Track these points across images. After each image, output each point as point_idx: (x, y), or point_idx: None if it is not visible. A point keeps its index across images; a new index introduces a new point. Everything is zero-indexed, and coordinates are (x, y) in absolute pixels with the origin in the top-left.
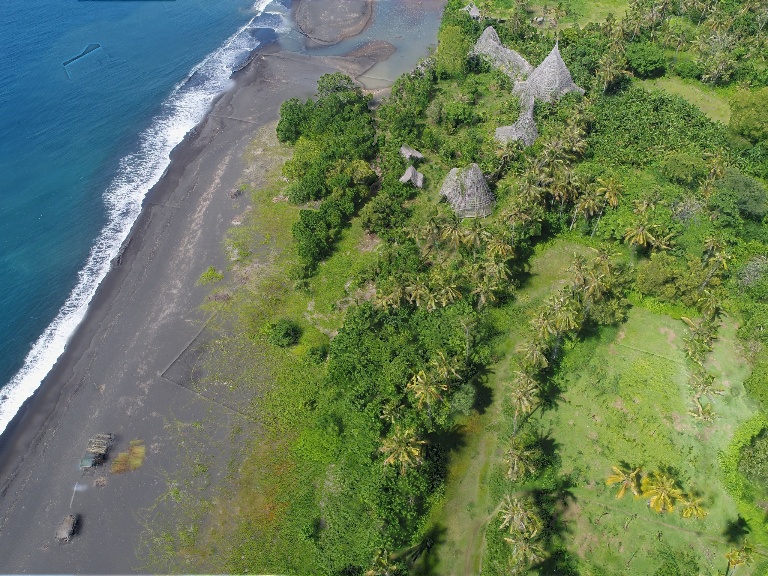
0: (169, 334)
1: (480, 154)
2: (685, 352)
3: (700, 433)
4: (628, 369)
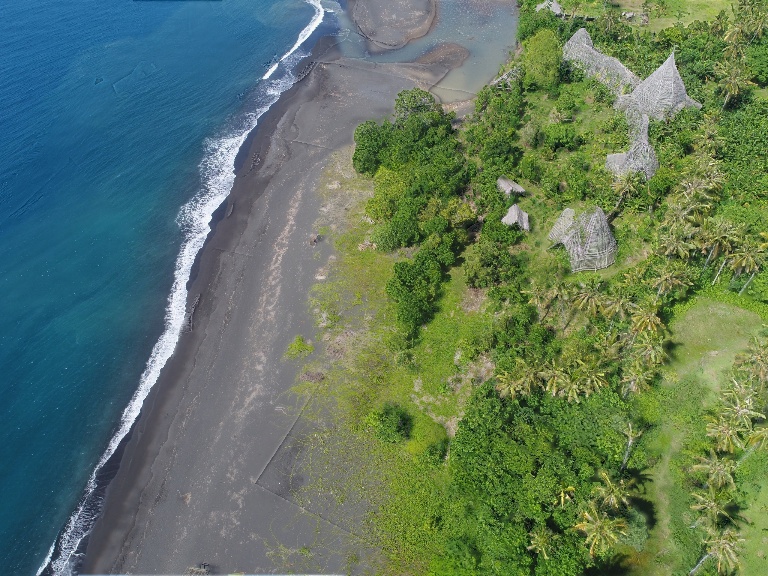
0: (259, 426)
1: (591, 187)
2: None
3: None
4: None
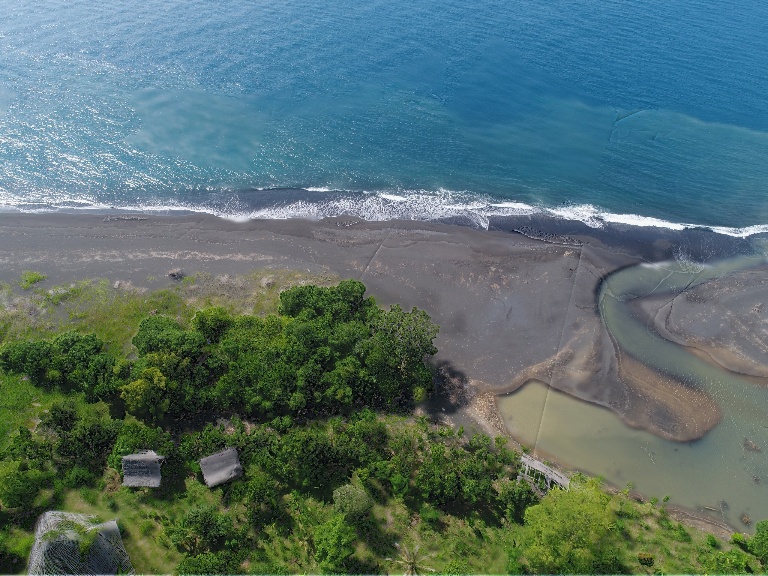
0: None
1: None
2: None
3: None
4: None
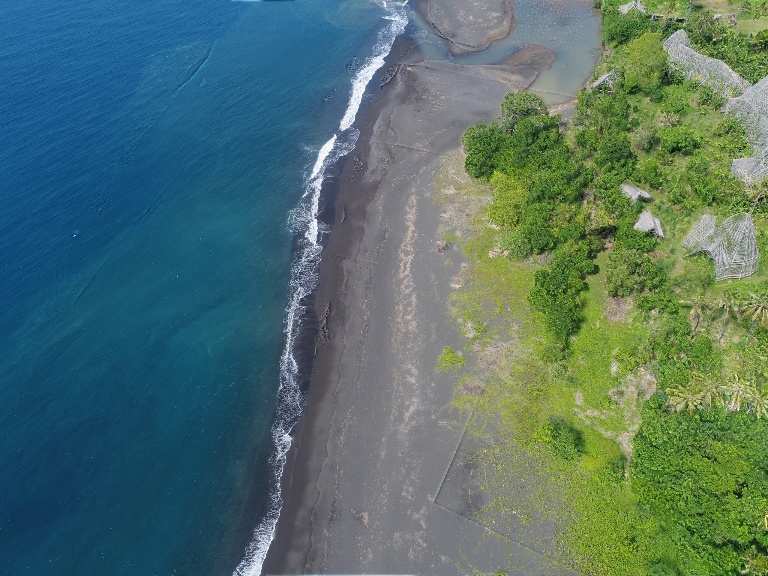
0: (426, 441)
1: (719, 192)
2: None
3: None
4: None
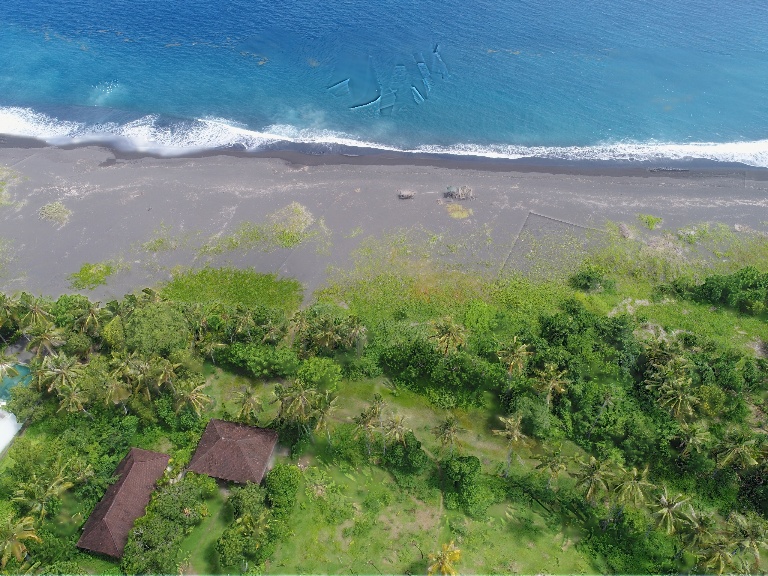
0: (573, 208)
1: None
2: None
3: None
4: None
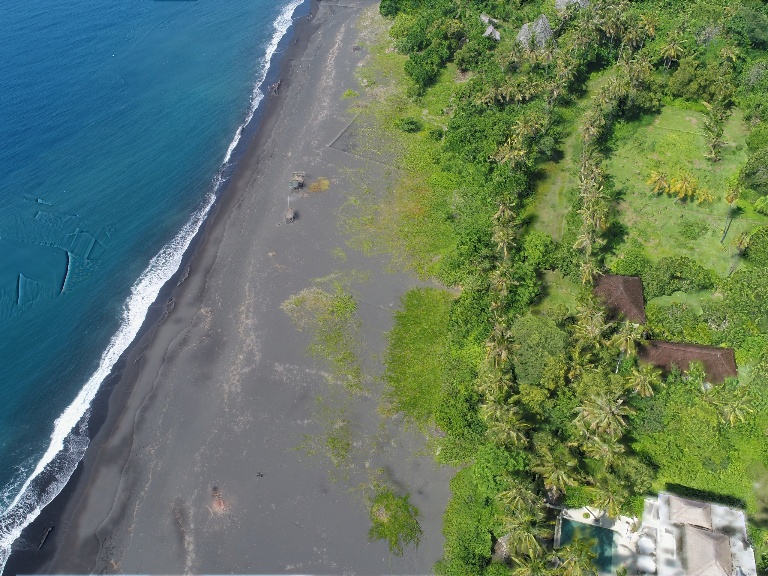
0: (328, 125)
1: None
2: (704, 129)
3: (713, 169)
4: (662, 139)
